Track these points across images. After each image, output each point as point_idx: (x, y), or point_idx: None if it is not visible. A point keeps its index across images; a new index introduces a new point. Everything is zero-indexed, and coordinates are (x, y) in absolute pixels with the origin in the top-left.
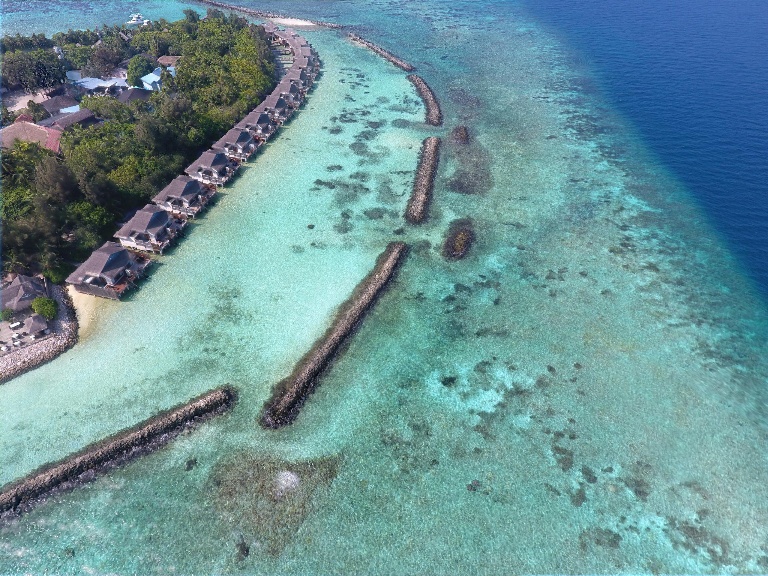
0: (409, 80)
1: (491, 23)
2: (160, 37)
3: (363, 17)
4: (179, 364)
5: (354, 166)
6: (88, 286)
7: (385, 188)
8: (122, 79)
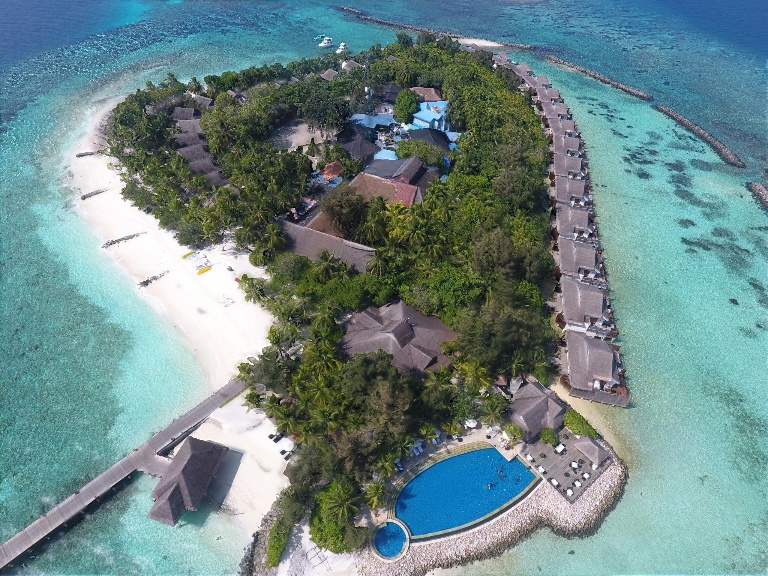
0: (659, 111)
1: (675, 42)
2: (410, 67)
3: (541, 36)
4: (767, 501)
5: (704, 220)
6: (595, 392)
7: (765, 249)
8: (389, 115)
